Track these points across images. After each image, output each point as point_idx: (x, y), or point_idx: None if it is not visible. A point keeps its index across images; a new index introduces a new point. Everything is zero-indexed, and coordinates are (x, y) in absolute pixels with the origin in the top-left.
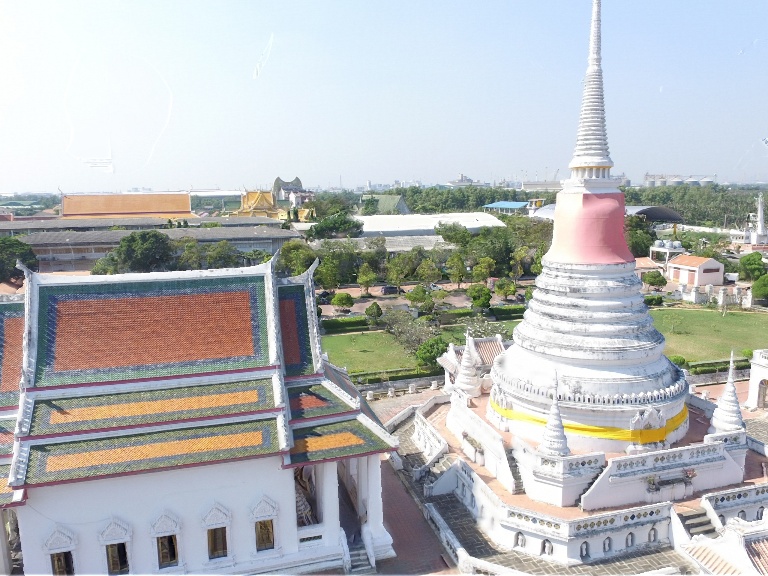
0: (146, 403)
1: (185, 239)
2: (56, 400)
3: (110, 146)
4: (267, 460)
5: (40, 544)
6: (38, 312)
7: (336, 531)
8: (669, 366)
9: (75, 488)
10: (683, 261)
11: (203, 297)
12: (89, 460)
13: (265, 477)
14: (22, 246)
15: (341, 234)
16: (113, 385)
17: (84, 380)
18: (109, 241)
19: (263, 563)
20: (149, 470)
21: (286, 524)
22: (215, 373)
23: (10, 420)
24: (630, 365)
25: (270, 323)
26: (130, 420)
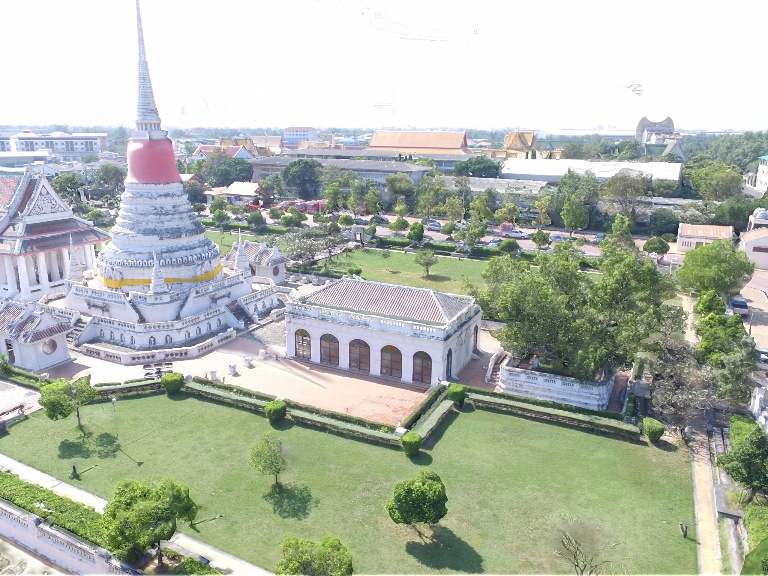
0: None
1: (330, 167)
2: None
3: (392, 92)
4: None
5: None
6: None
7: (11, 288)
8: (156, 252)
9: None
10: (749, 235)
11: (6, 179)
12: None
13: None
14: (244, 164)
15: (476, 174)
16: None
17: None
18: None
19: None
20: None
21: None
22: None
23: None
24: (123, 244)
25: None
26: None
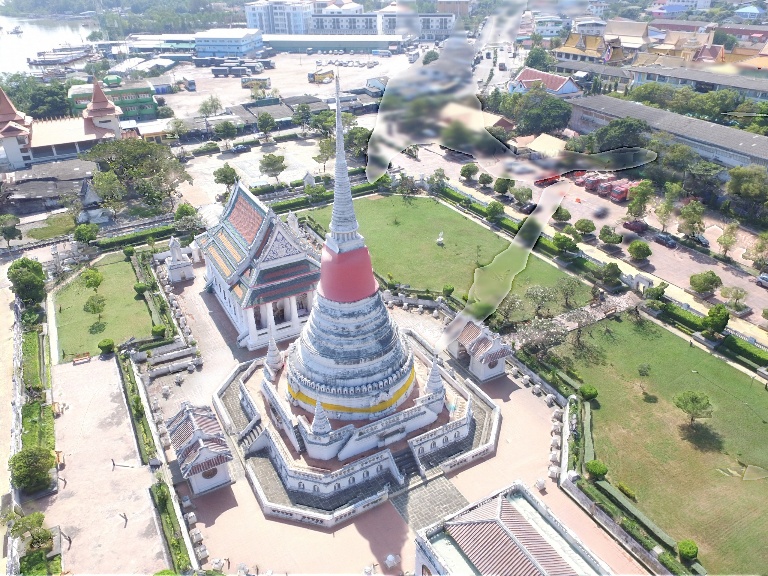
0: None
1: (661, 134)
2: None
3: None
4: None
5: None
6: None
7: None
8: (331, 375)
9: None
10: None
11: None
12: None
13: None
14: (560, 109)
15: None
16: None
17: None
18: (624, 117)
19: None
20: None
21: None
22: None
23: None
24: None
25: None
26: None
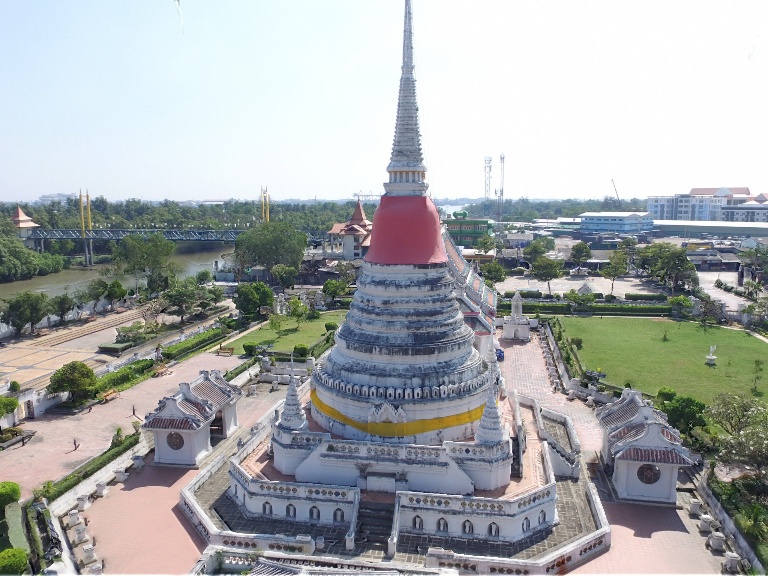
0: None
1: None
2: None
3: None
4: None
5: None
6: None
7: None
8: (339, 365)
9: None
10: None
11: None
12: None
13: None
14: None
15: None
16: None
17: None
18: None
19: None
20: None
21: None
22: None
23: None
24: None
25: None
26: None
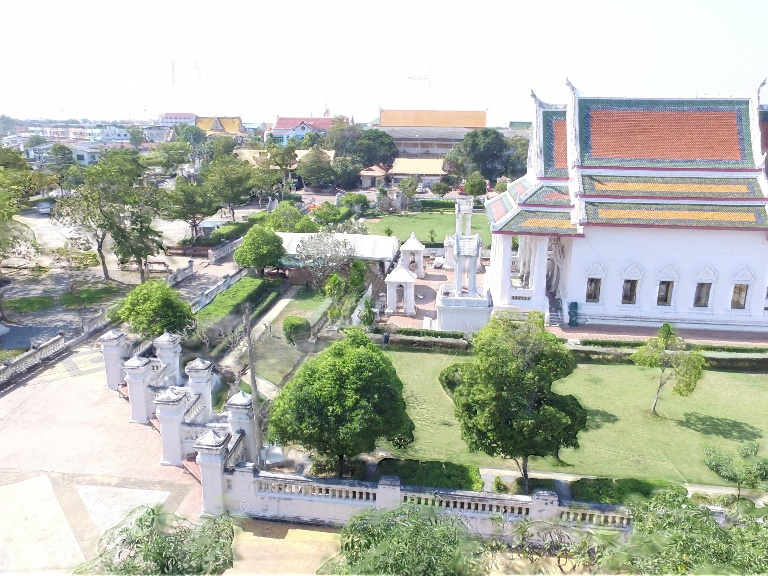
0: (660, 184)
1: (518, 138)
2: (595, 176)
3: (429, 63)
4: (755, 236)
5: (583, 270)
6: (578, 116)
7: None
8: None
9: (613, 234)
10: None
11: (698, 114)
12: (627, 214)
13: (749, 250)
14: (388, 137)
15: None
16: (634, 170)
17: (614, 164)
18: (450, 138)
19: (735, 317)
20: (671, 226)
21: (758, 292)
22: (711, 170)
23: (563, 187)
24: None
25: (754, 137)
26: (651, 193)
